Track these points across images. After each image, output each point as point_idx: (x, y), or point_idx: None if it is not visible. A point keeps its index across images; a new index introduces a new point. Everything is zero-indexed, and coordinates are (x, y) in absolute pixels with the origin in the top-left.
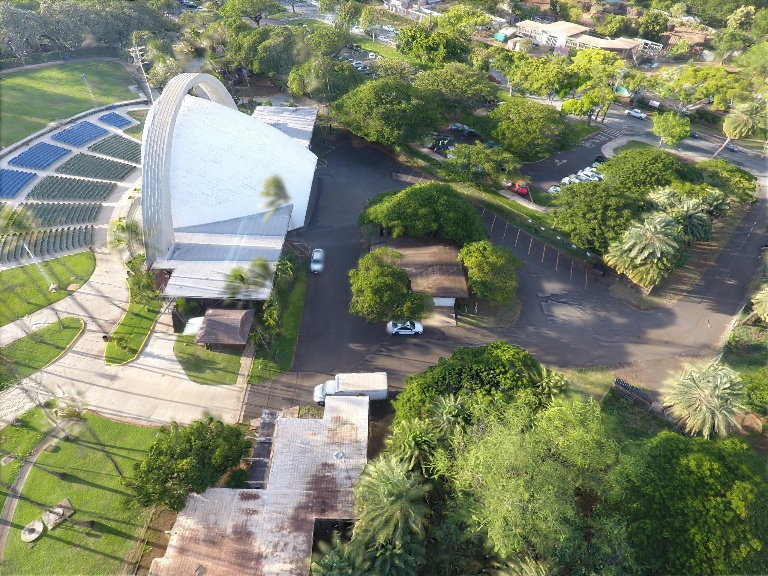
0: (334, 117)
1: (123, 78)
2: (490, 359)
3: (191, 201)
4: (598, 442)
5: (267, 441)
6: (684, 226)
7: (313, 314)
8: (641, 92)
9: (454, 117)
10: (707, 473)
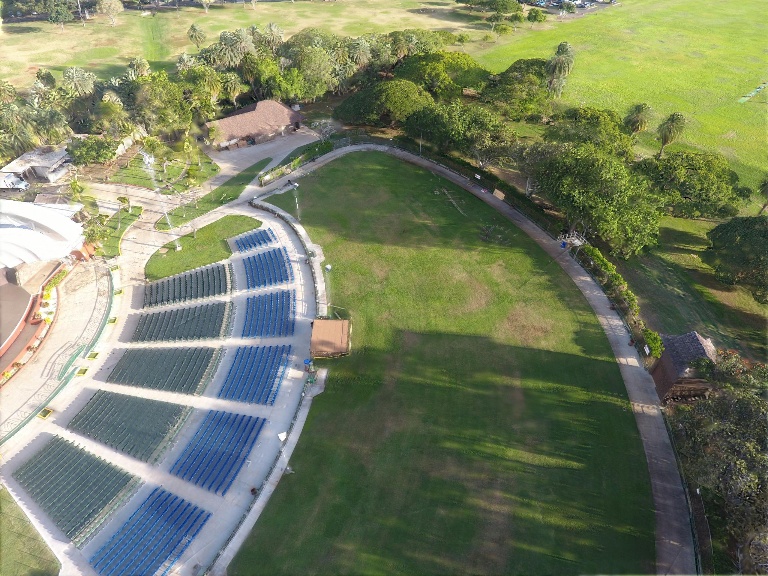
0: None
1: None
2: None
3: None
4: None
5: None
6: None
7: None
8: None
9: None
10: None
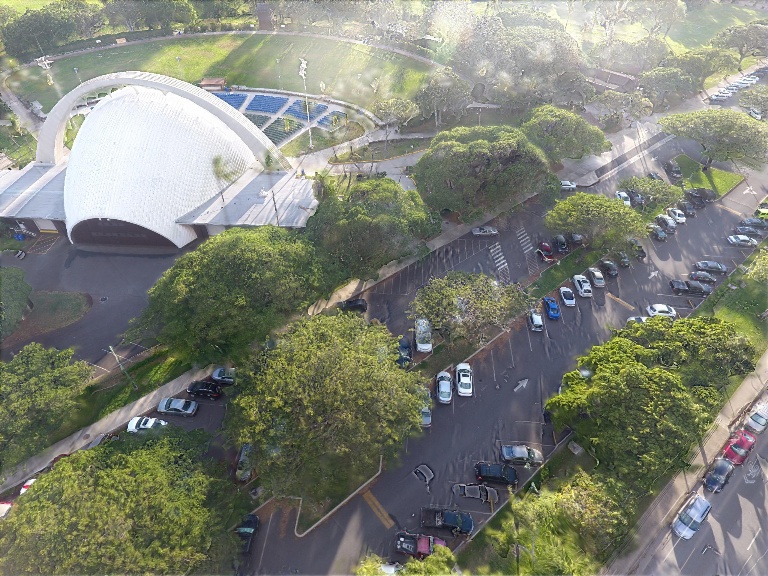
0: None
1: None
2: None
3: None
4: None
5: None
6: None
7: None
8: None
9: None
10: None
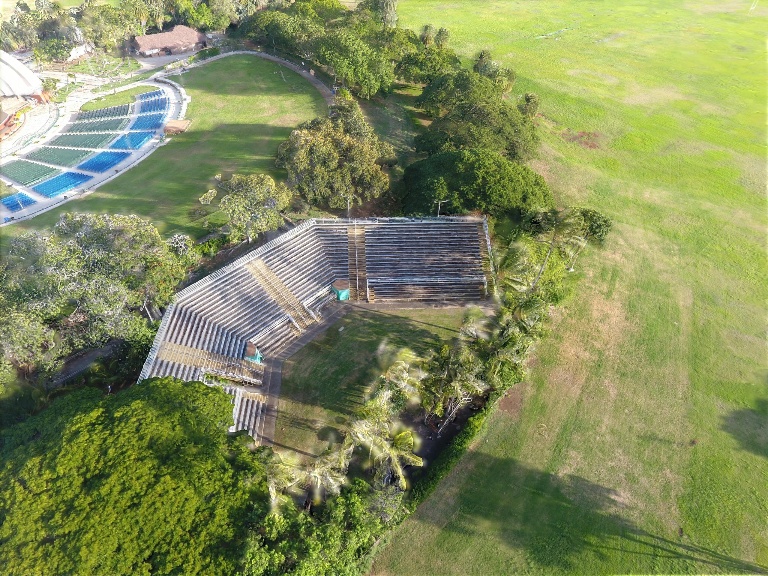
0: None
1: None
2: None
3: None
4: None
5: None
6: None
7: None
8: None
9: None
10: None
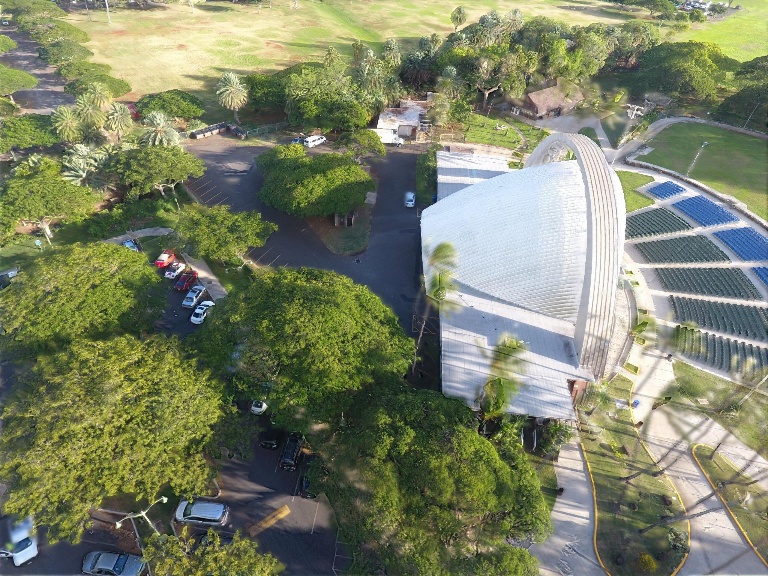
0: None
1: None
2: (320, 103)
3: None
4: None
5: None
6: None
7: (409, 174)
8: None
9: None
10: None
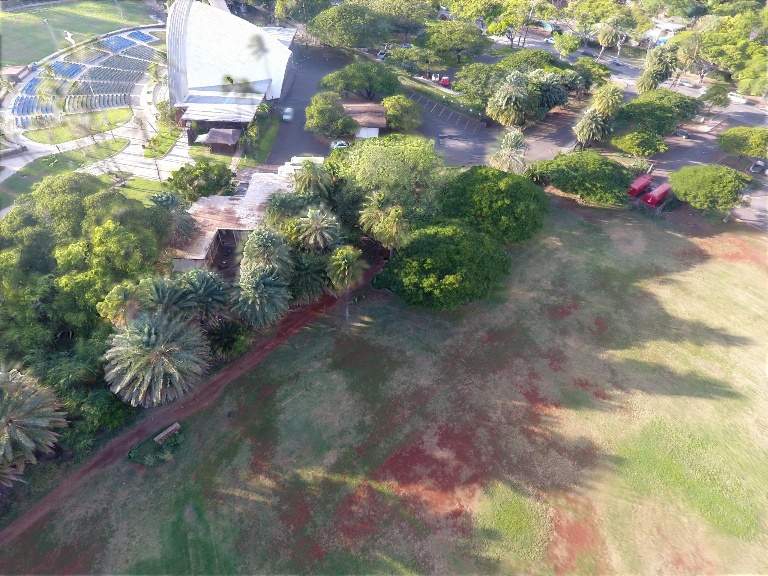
0: (308, 32)
1: (145, 10)
2: None
3: (200, 68)
4: (430, 158)
5: (246, 183)
6: (542, 90)
7: (282, 140)
8: (563, 28)
9: (406, 40)
10: (490, 174)
